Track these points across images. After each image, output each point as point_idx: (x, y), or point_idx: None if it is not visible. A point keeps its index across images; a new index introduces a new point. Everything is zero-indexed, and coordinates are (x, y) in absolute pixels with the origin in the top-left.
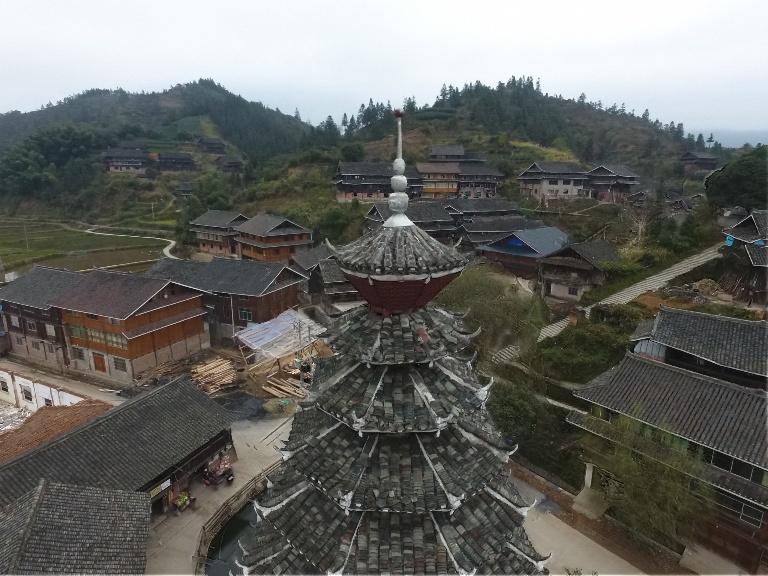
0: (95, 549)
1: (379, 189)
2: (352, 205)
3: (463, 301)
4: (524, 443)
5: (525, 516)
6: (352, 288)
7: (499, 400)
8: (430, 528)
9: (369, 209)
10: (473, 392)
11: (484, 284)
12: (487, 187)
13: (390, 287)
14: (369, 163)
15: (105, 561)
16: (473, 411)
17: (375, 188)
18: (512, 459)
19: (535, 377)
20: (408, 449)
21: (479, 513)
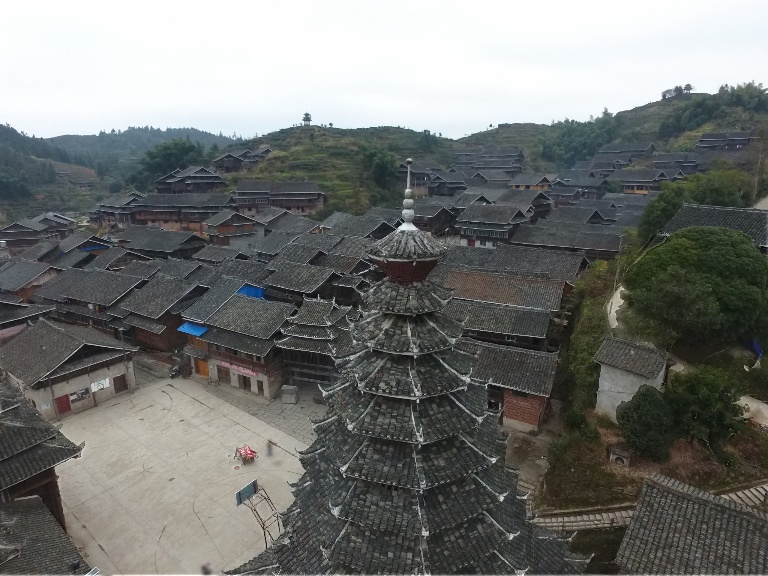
0: (731, 569)
1: None
2: None
3: None
4: None
5: None
6: None
7: None
8: None
9: None
10: None
11: None
12: None
13: None
14: None
15: (712, 571)
16: None
17: None
18: None
19: None
20: None
21: None
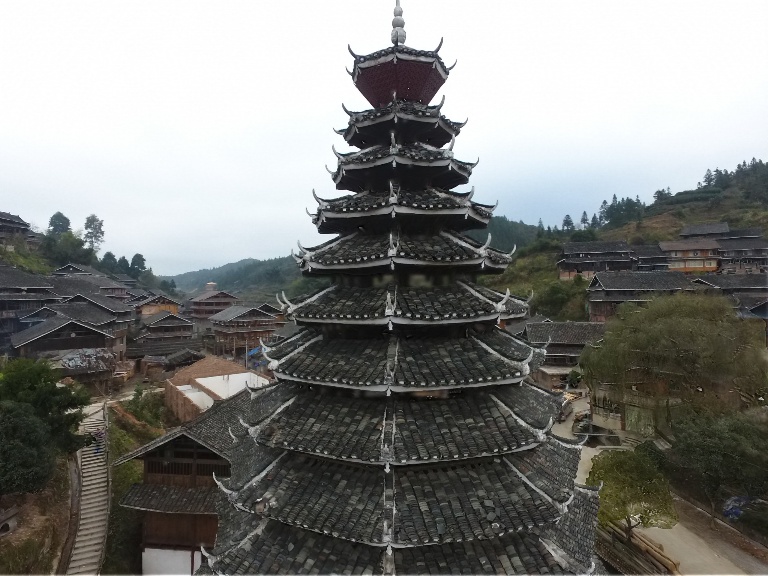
0: None
1: (608, 266)
2: (574, 281)
3: (656, 320)
4: (761, 515)
5: (482, 254)
6: (560, 351)
7: (699, 430)
8: (386, 241)
9: (590, 281)
10: (441, 153)
11: (688, 305)
12: (764, 264)
13: (374, 74)
14: (597, 242)
15: None
16: (433, 158)
17: (603, 266)
18: (737, 530)
19: (764, 413)
20: (383, 193)
21: (438, 247)
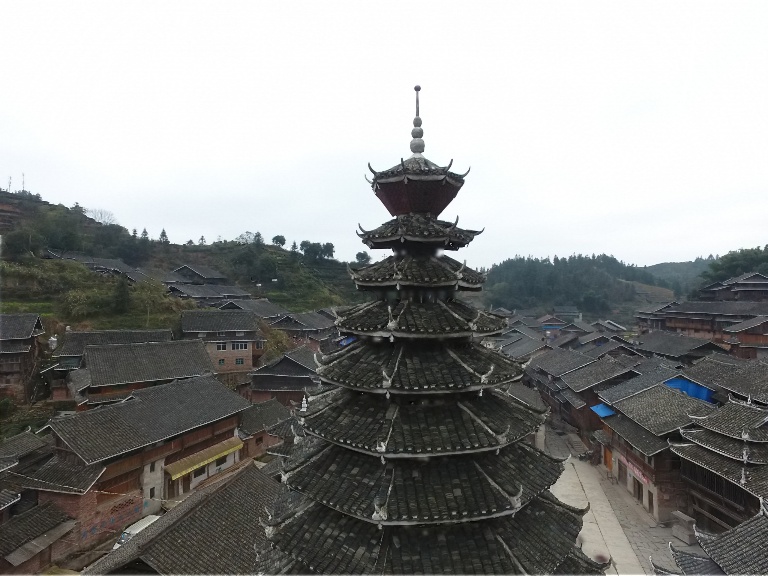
0: None
1: None
2: None
3: None
4: None
5: None
6: None
7: None
8: None
9: None
10: None
11: None
12: None
13: None
14: None
15: None
16: None
17: None
18: None
19: None
20: None
21: None
